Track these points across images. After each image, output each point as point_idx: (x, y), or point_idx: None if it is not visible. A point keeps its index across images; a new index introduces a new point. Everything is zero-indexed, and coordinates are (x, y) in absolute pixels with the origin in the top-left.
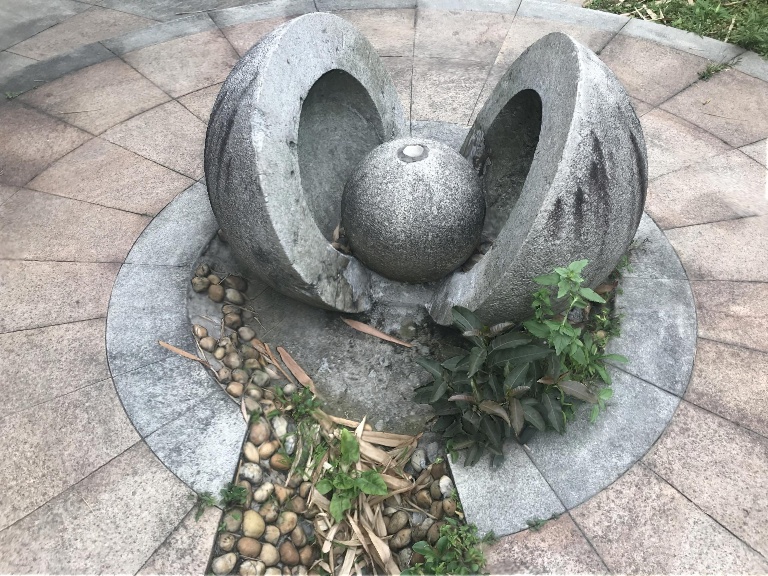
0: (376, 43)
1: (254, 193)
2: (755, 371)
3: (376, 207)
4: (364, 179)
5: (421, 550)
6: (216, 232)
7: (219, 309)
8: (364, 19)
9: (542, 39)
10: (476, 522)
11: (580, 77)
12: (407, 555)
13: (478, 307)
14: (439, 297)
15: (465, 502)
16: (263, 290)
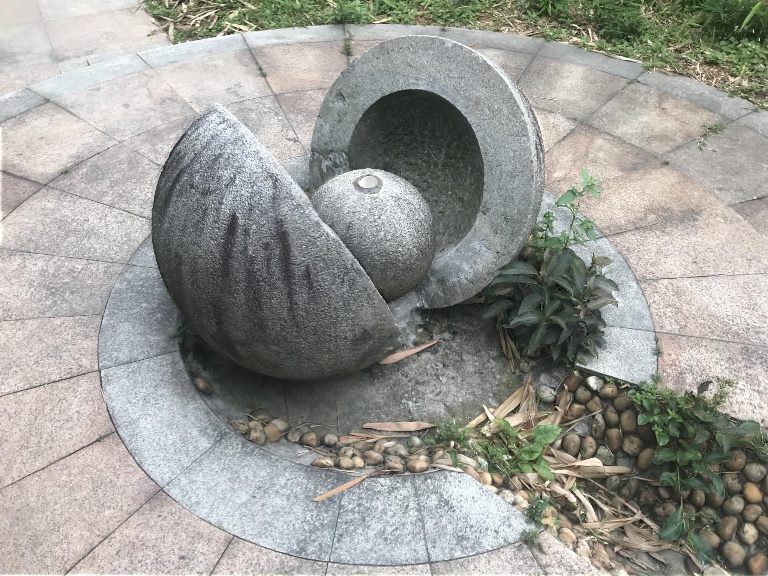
0: (64, 149)
1: (354, 280)
2: (606, 199)
3: (384, 242)
4: (353, 228)
5: (645, 420)
6: (197, 391)
7: (287, 444)
8: (12, 135)
9: (371, 51)
10: (640, 379)
11: (482, 56)
12: (606, 450)
13: (512, 257)
14: (431, 289)
15: (621, 376)
16: (284, 403)
